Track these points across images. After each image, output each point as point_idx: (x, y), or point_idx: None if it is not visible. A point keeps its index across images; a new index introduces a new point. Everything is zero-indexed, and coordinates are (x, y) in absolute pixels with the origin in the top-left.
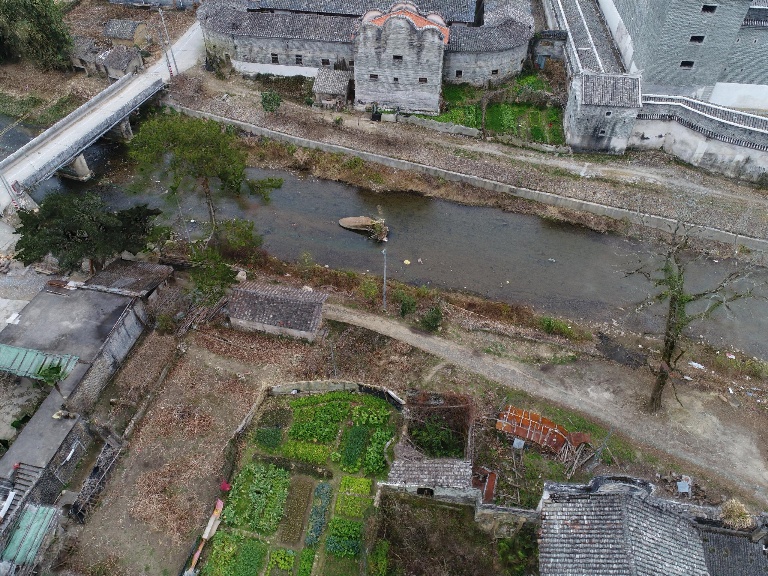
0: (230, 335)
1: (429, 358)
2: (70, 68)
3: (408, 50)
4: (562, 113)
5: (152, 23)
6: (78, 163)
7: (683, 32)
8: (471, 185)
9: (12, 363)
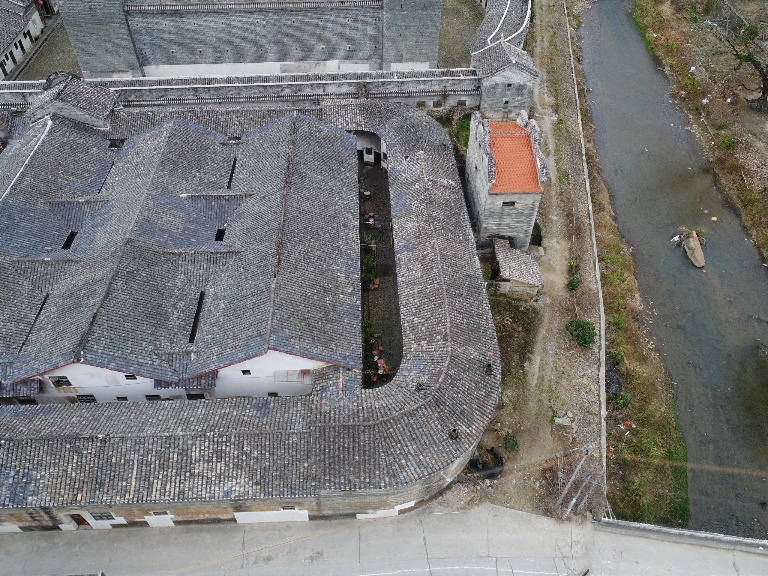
0: None
1: None
2: None
3: None
4: None
5: None
6: None
7: None
8: None
9: None
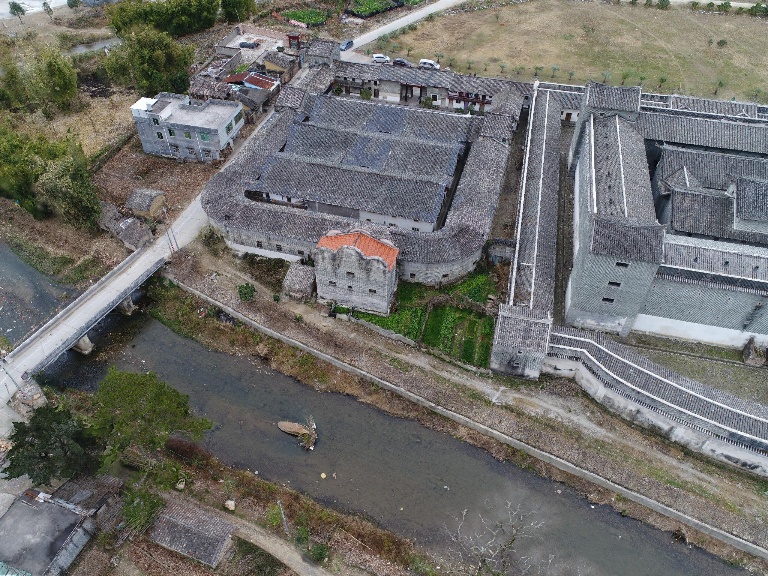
0: (155, 551)
1: None
2: (98, 228)
3: (359, 270)
4: (494, 328)
5: (175, 177)
6: (81, 342)
7: (601, 278)
8: (399, 395)
9: None
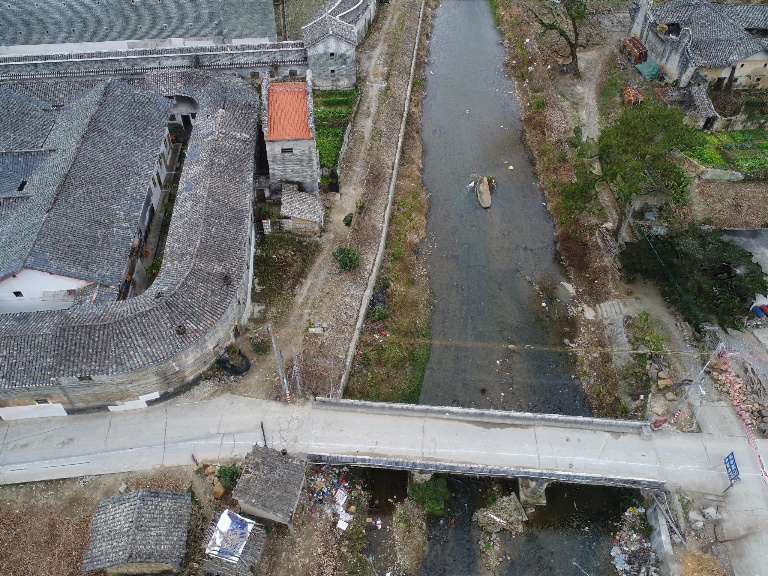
0: None
1: None
2: None
3: None
4: None
5: None
6: None
7: None
8: None
9: None
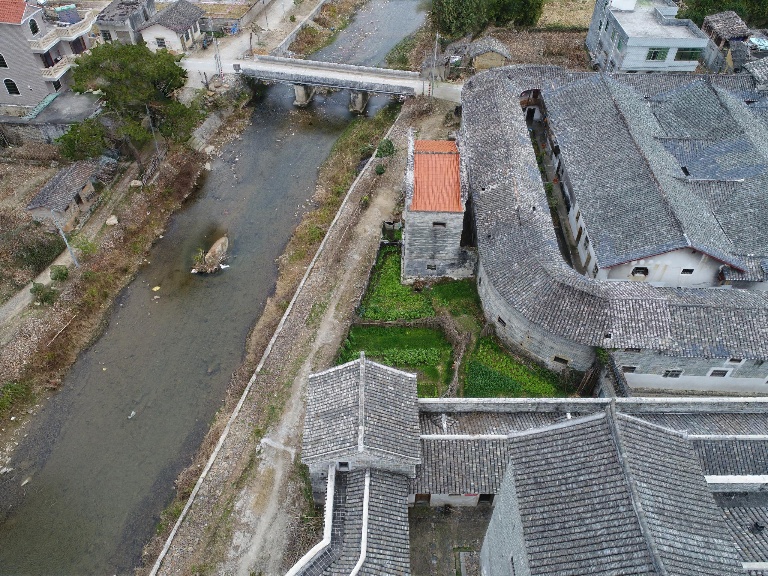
0: None
1: (3, 296)
2: None
3: None
4: None
5: None
6: (296, 90)
7: None
8: None
9: (44, 101)
